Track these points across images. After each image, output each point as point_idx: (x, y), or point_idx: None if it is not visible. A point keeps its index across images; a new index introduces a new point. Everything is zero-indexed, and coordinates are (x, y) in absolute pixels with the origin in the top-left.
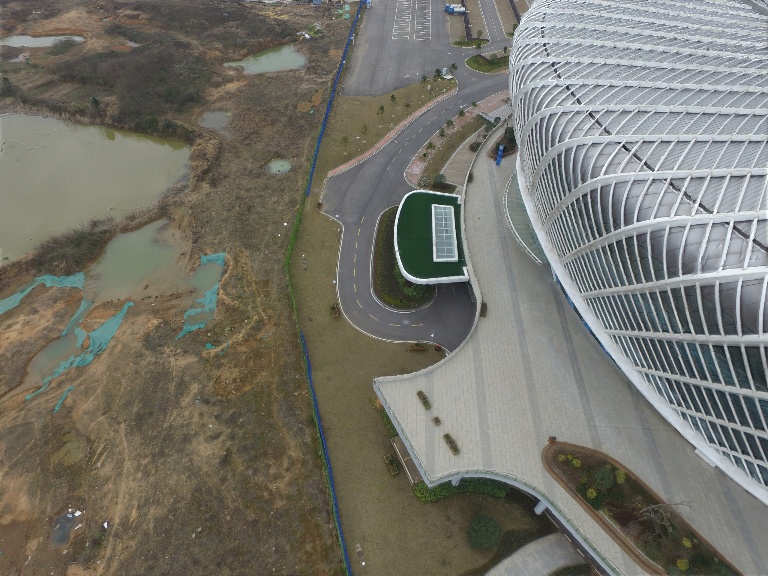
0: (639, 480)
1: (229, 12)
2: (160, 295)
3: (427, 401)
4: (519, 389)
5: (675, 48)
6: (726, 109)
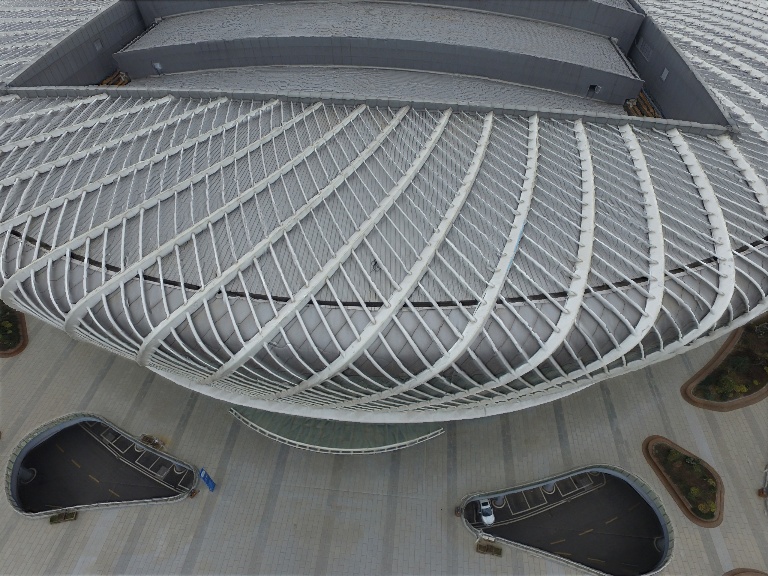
0: None
1: None
2: None
3: None
4: None
5: None
6: (17, 7)
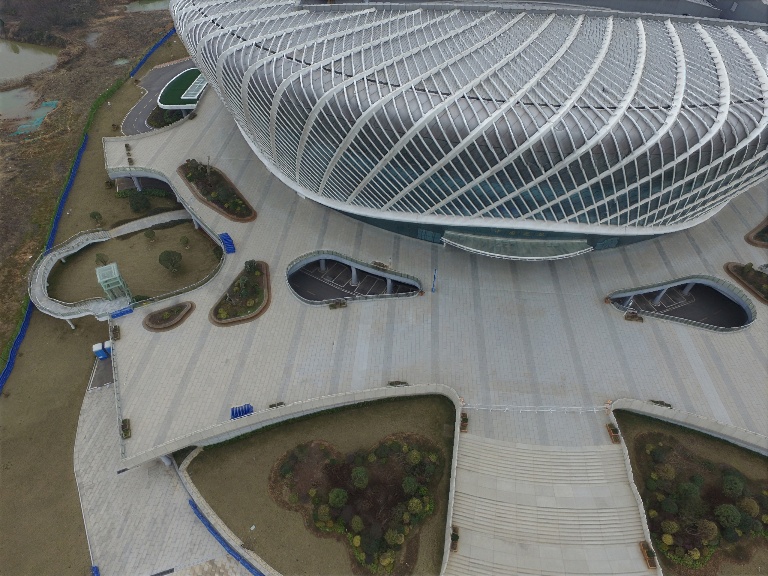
0: (224, 175)
1: None
2: (7, 119)
3: (128, 147)
4: (187, 145)
5: None
6: None
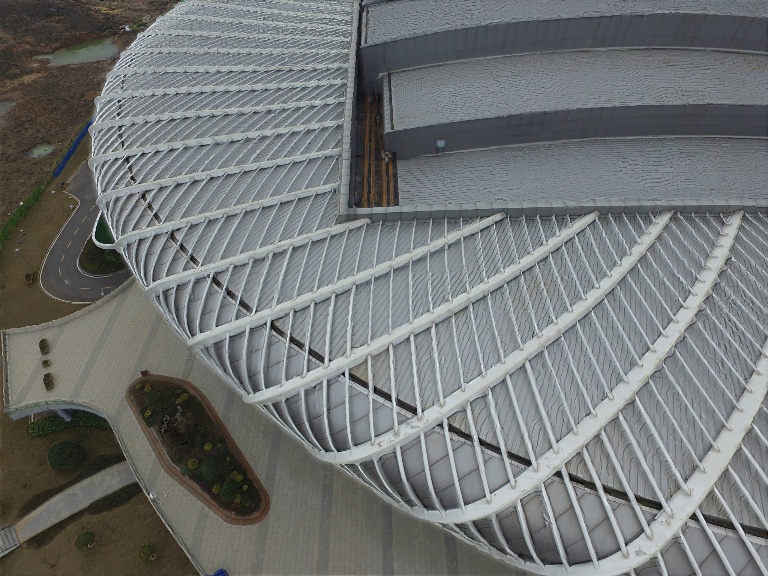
0: (204, 401)
1: (59, 7)
2: None
3: (44, 347)
4: (141, 333)
5: (239, 20)
6: (211, 67)
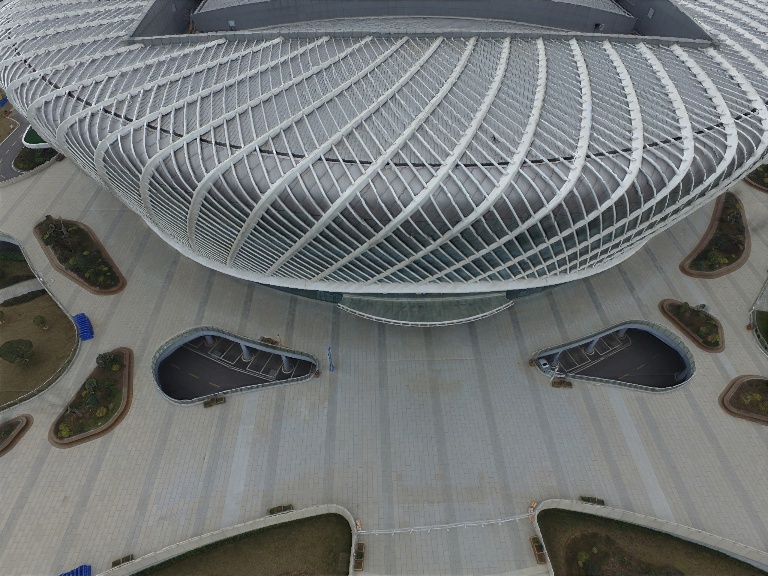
0: (90, 232)
1: None
2: None
3: None
4: (51, 196)
5: None
6: None
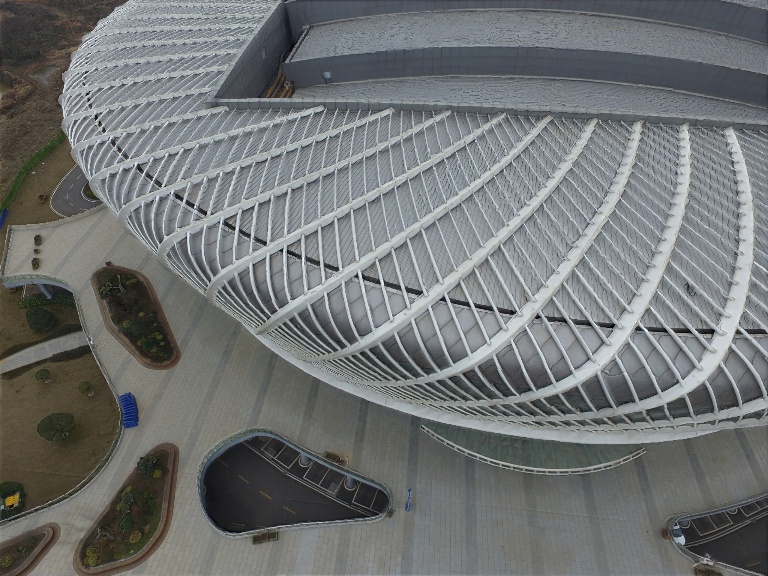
0: (149, 286)
1: None
2: None
3: (38, 240)
4: (114, 237)
5: None
6: (167, 15)
